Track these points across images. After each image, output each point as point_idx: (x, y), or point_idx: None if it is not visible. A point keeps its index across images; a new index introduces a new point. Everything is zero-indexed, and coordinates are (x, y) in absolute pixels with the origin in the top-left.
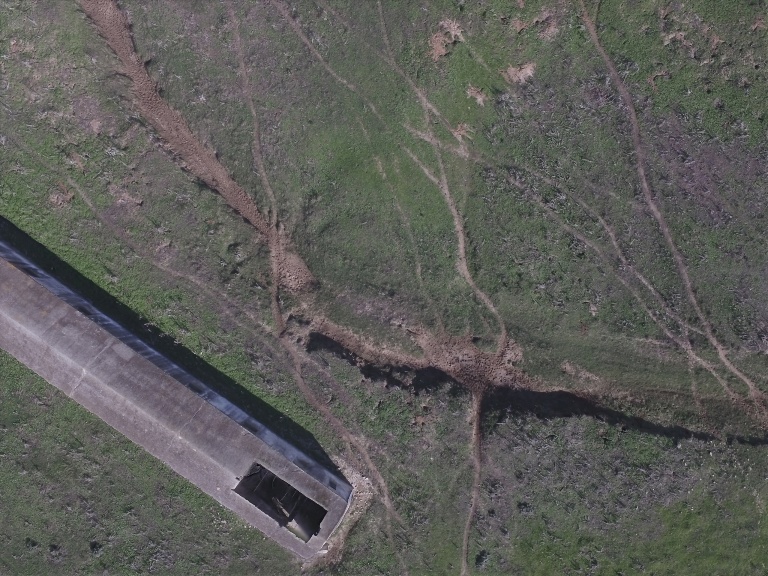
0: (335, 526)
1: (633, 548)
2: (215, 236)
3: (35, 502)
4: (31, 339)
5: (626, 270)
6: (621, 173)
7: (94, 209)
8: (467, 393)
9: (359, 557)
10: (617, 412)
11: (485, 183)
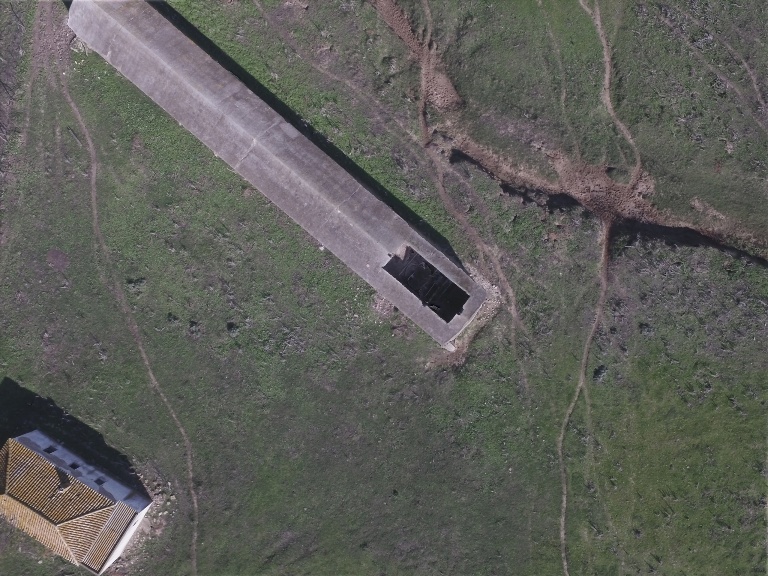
0: (474, 313)
1: (747, 376)
2: (373, 45)
3: (180, 280)
4: (207, 107)
5: (764, 113)
6: (767, 21)
7: (262, 9)
8: (598, 218)
9: (482, 361)
10: (740, 250)
11: (636, 17)
